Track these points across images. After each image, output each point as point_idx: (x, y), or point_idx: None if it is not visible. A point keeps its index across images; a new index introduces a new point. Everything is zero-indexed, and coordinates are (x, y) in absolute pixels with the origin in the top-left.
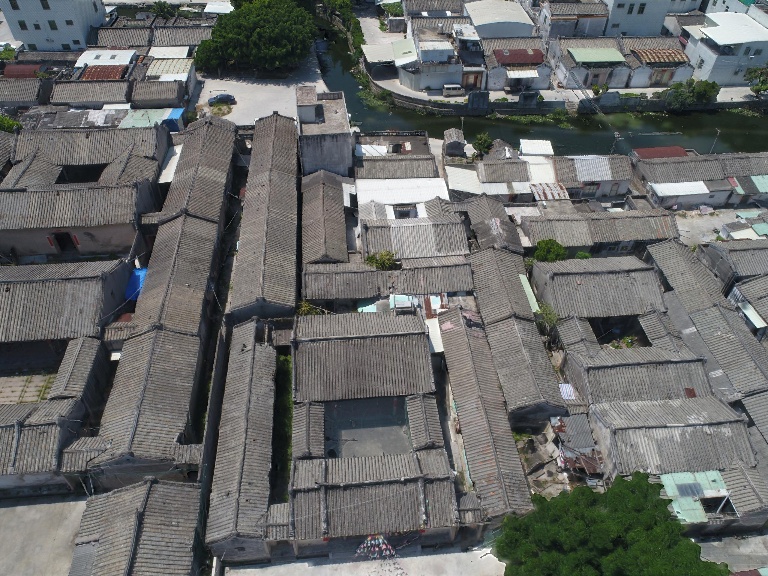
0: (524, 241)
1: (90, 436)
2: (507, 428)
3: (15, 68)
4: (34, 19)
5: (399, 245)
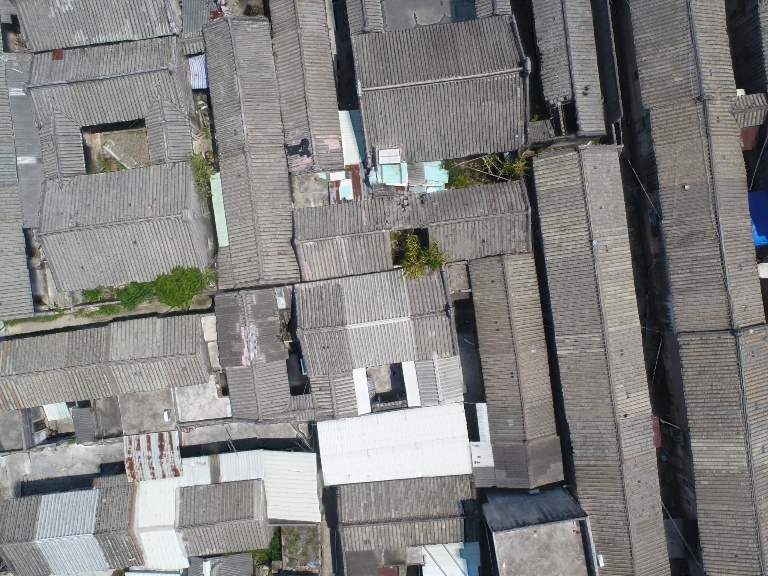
0: (211, 330)
1: (728, 6)
2: (273, 0)
3: None
4: None
5: (397, 290)
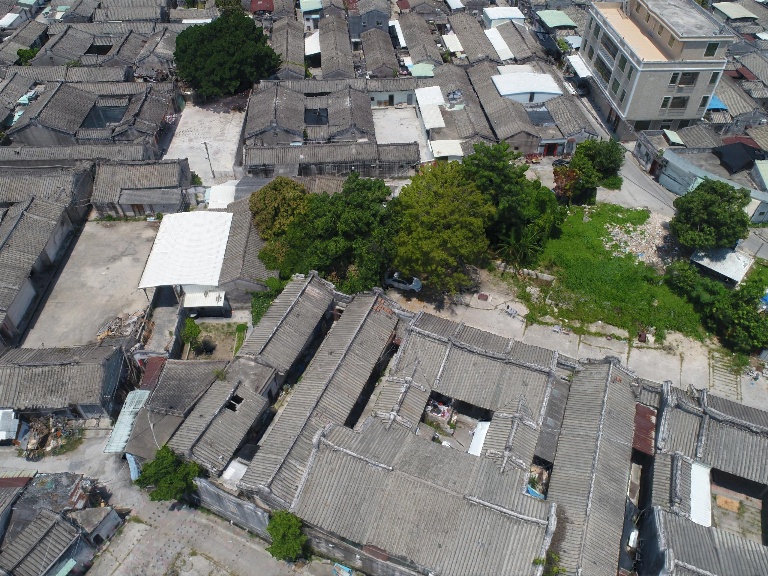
0: None
1: None
2: None
3: None
4: None
5: None
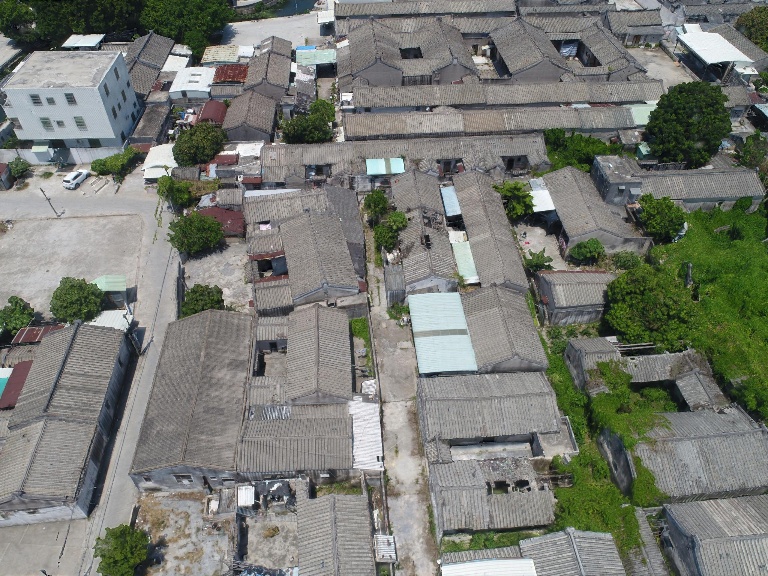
0: None
1: None
2: None
3: (213, 113)
4: (116, 98)
5: None
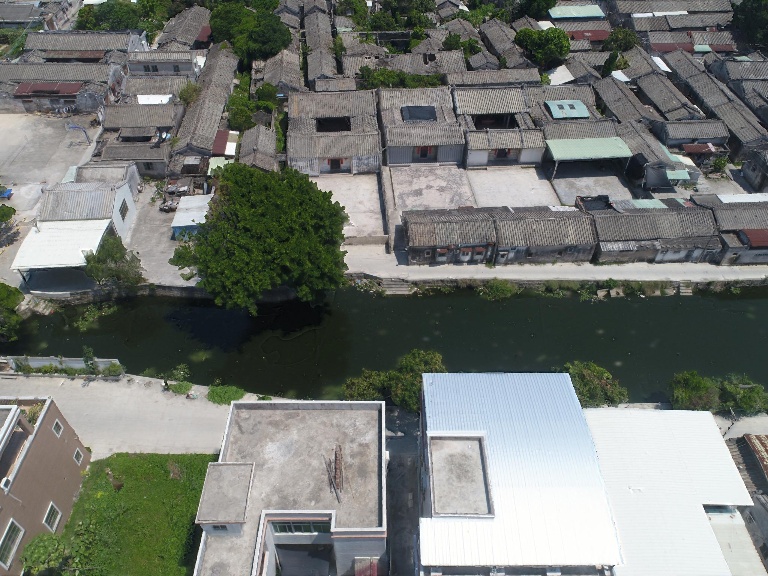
0: None
1: None
2: None
3: None
4: None
5: None
